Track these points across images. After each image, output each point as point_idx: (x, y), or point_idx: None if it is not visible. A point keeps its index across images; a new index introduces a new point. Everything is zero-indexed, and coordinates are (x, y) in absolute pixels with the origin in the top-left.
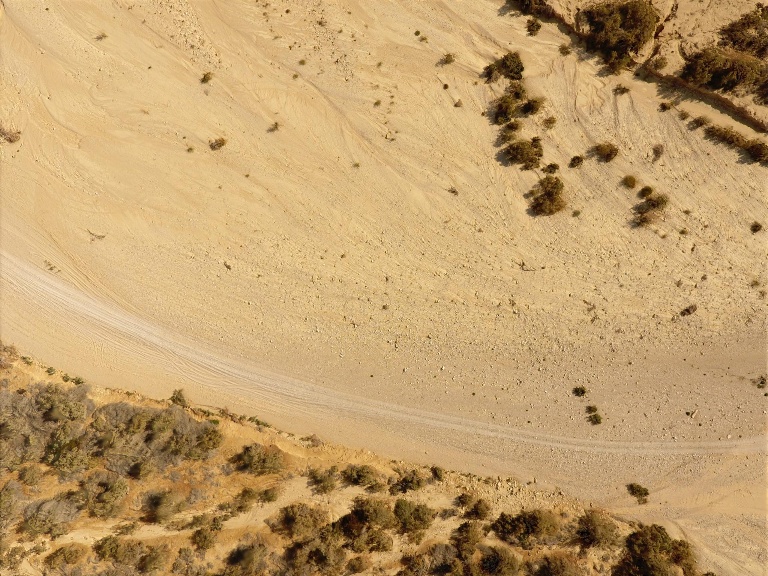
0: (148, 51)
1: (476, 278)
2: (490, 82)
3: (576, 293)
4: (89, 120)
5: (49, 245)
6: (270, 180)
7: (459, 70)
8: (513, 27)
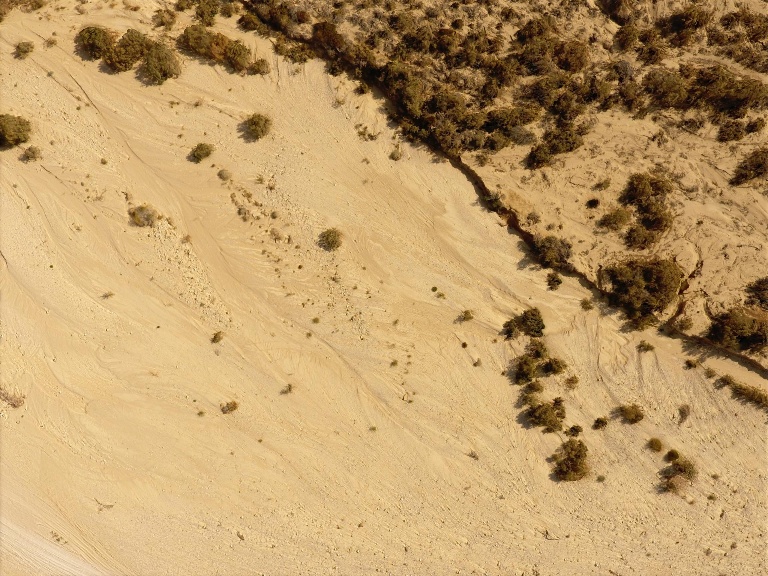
0: (156, 310)
1: (498, 547)
2: (510, 339)
3: (602, 563)
4: (96, 383)
5: (55, 515)
6: (284, 445)
7: (478, 327)
8: (533, 281)
